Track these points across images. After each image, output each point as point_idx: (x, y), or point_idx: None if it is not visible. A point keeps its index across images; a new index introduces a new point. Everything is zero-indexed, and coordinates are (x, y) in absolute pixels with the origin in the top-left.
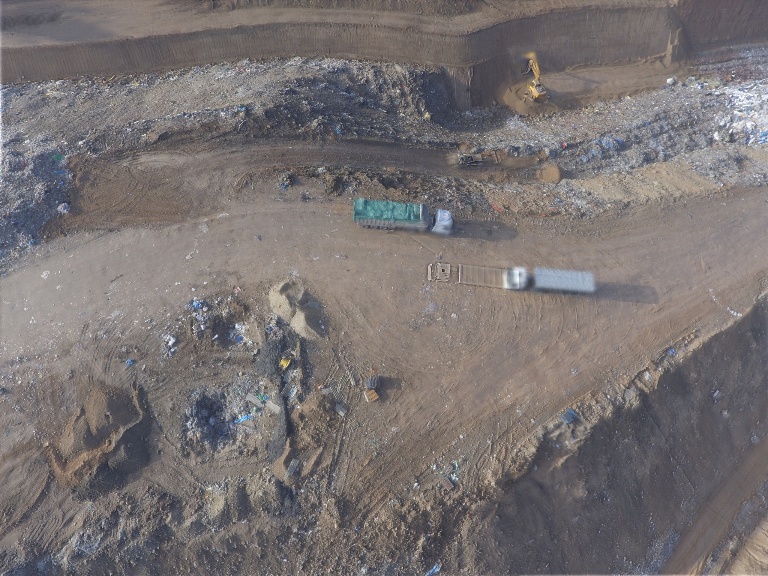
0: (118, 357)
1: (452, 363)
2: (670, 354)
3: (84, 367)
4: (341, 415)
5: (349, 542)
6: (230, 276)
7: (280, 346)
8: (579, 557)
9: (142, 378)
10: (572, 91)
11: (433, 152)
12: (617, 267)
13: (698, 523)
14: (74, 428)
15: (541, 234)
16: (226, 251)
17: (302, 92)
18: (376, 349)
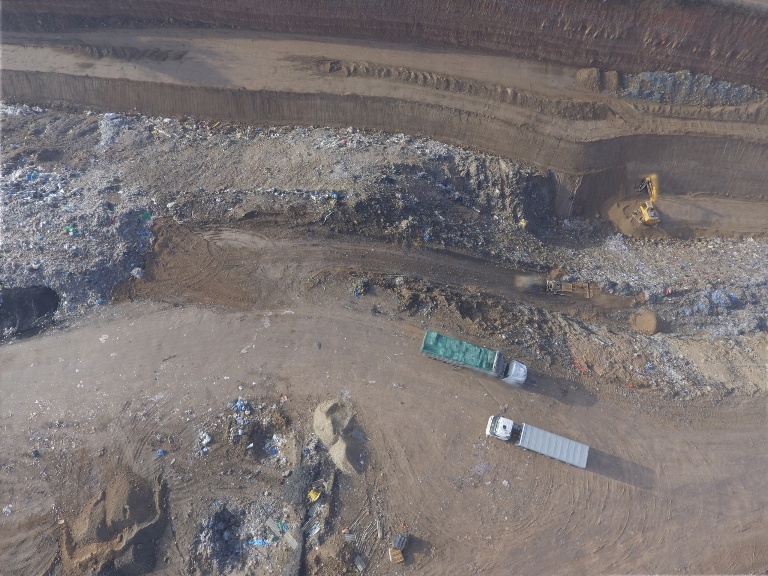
0: (151, 444)
1: (492, 539)
2: None
3: (116, 447)
4: (359, 569)
5: None
6: (280, 382)
7: (313, 473)
8: None
9: (169, 473)
10: (687, 219)
11: (521, 274)
12: (704, 466)
13: None
14: (91, 513)
15: (623, 407)
16: (282, 353)
17: (398, 181)
18: (413, 502)
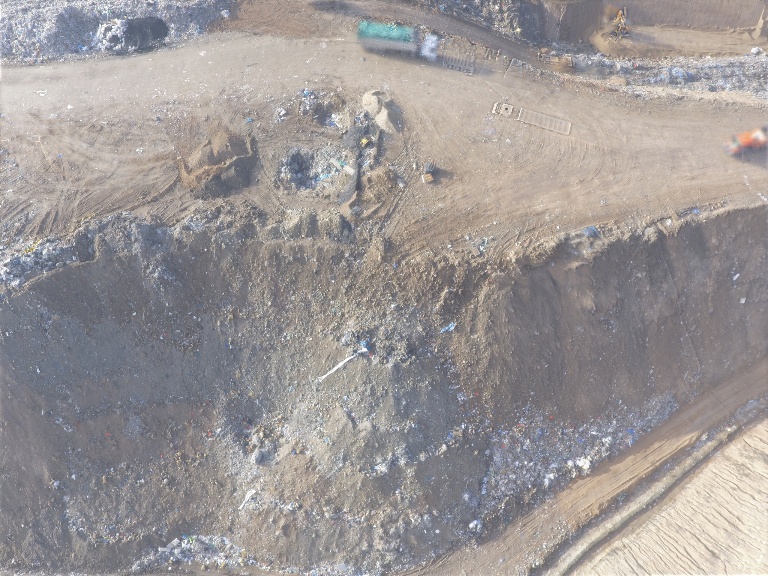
0: (242, 114)
1: (499, 172)
2: (695, 213)
3: (217, 116)
4: (401, 186)
5: (386, 277)
6: (336, 79)
7: (364, 131)
8: (577, 373)
9: (256, 132)
10: (655, 43)
11: (517, 45)
12: (660, 139)
13: (699, 405)
14: (202, 149)
15: (597, 101)
16: (337, 63)
17: None
18: (439, 149)
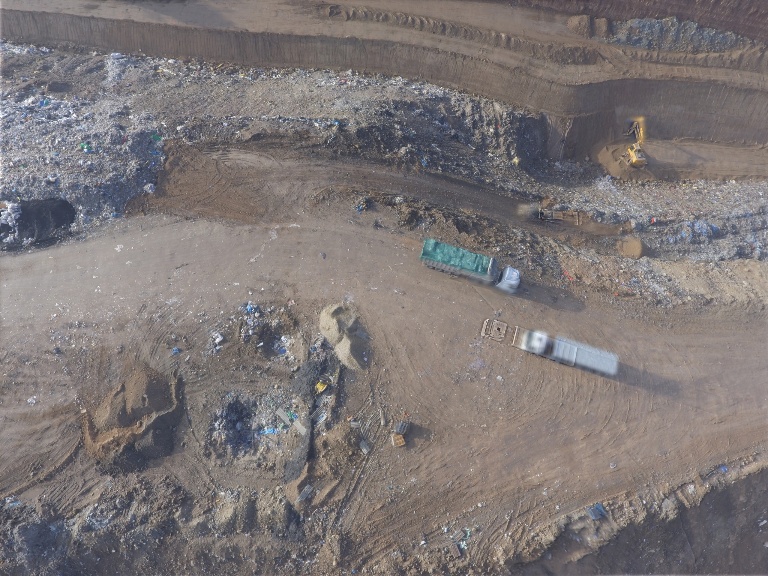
0: (166, 343)
1: (487, 427)
2: (722, 472)
3: (134, 345)
4: (364, 452)
5: None
6: (288, 288)
7: (320, 368)
8: None
9: (184, 368)
10: (673, 162)
11: (514, 201)
12: (684, 366)
13: None
14: (112, 402)
15: (609, 313)
16: (289, 262)
17: (396, 115)
18: (413, 394)
